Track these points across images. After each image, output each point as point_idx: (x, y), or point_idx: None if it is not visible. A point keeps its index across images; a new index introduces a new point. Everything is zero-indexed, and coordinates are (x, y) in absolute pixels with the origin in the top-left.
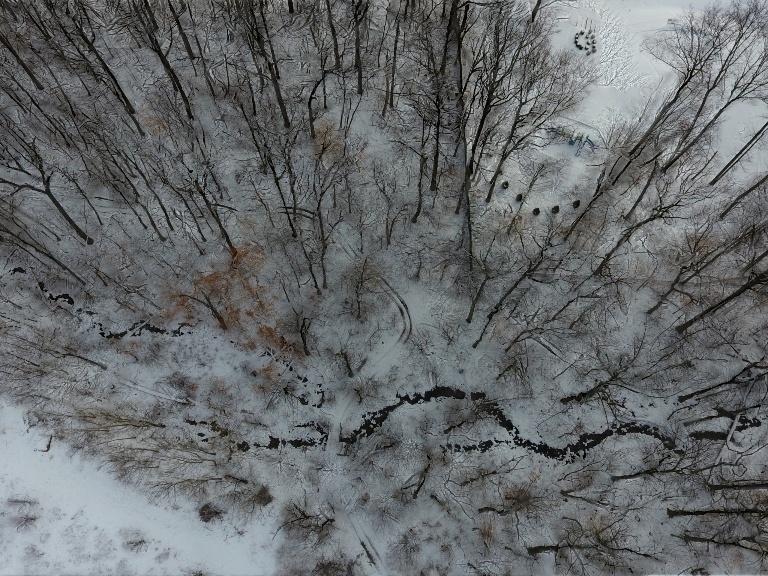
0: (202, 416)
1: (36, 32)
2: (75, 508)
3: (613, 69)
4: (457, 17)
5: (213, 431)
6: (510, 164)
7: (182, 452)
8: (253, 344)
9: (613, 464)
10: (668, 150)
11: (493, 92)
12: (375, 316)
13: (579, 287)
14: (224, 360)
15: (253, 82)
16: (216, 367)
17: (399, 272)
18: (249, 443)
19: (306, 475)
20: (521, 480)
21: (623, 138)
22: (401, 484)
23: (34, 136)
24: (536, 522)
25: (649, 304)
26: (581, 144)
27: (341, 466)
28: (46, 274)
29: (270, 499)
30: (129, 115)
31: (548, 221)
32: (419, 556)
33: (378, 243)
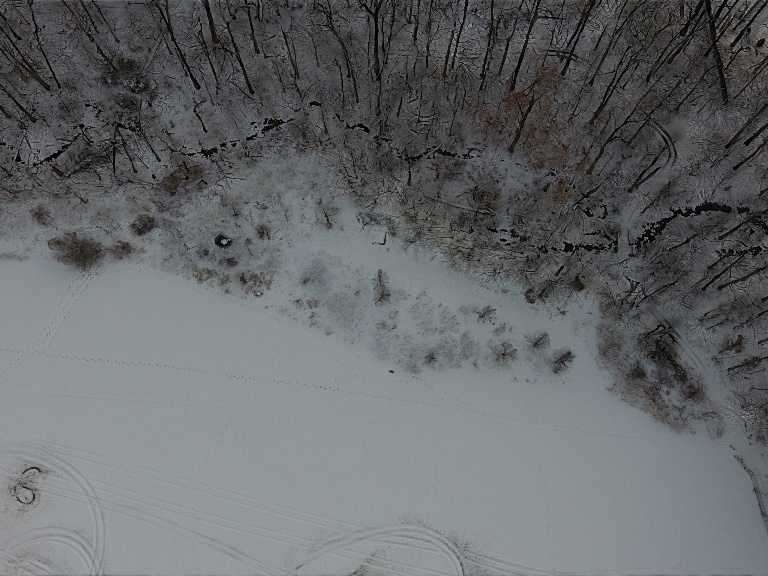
0: (502, 224)
1: None
2: (418, 290)
3: None
4: None
5: (513, 237)
6: None
7: (494, 251)
8: (542, 163)
9: None
10: None
11: None
12: (644, 142)
13: None
14: (515, 178)
15: None
16: (508, 184)
17: None
18: (547, 247)
19: (605, 271)
20: None
21: None
22: (703, 270)
23: None
24: None
25: None
26: None
27: (634, 264)
28: (342, 106)
29: (583, 286)
30: None
31: None
32: (715, 336)
33: (638, 81)
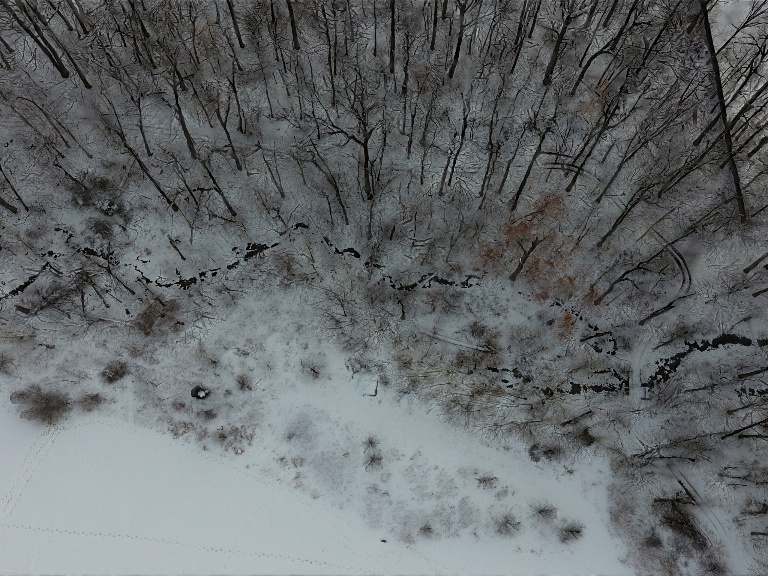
0: (504, 363)
1: None
2: (412, 449)
3: None
4: None
5: (516, 378)
6: None
7: (495, 397)
8: (546, 294)
9: None
10: None
11: None
12: (656, 267)
13: None
14: (517, 310)
15: (509, 41)
16: (510, 317)
17: (672, 225)
18: (552, 389)
19: (615, 418)
20: None
21: None
22: (723, 424)
23: (300, 95)
24: None
25: None
26: None
27: (647, 409)
28: (330, 229)
29: (592, 440)
30: (405, 72)
31: None
32: (737, 493)
33: None
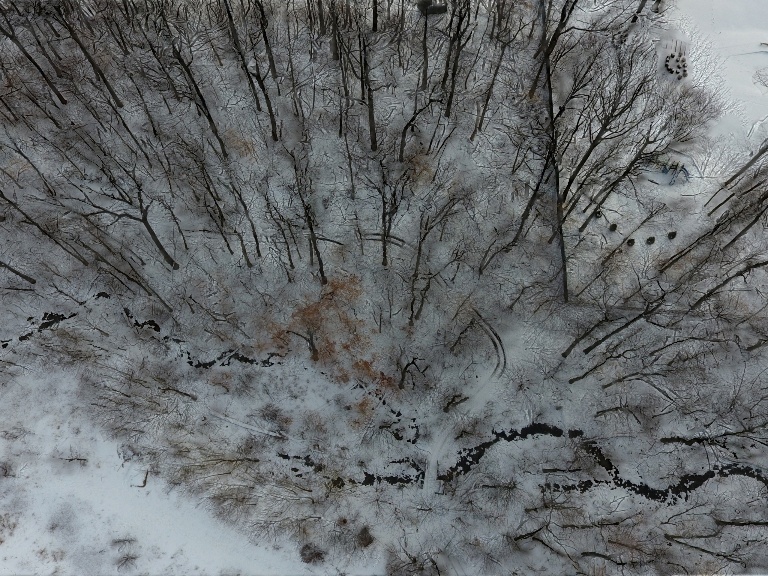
0: (295, 450)
1: (115, 48)
2: (174, 547)
3: (706, 94)
4: (546, 38)
5: (307, 466)
6: (609, 195)
7: (278, 488)
8: (346, 377)
9: (719, 508)
10: (767, 181)
11: (607, 125)
12: (469, 349)
13: (678, 322)
14: (316, 392)
15: (338, 103)
16: (308, 400)
17: (491, 303)
18: (344, 479)
19: (404, 514)
20: (624, 523)
21: (720, 167)
22: (507, 528)
23: None
24: (640, 567)
25: (749, 341)
26: (675, 173)
27: (439, 505)
28: (131, 300)
29: (371, 540)
30: (216, 137)
31: (644, 253)
32: None
33: (470, 273)
